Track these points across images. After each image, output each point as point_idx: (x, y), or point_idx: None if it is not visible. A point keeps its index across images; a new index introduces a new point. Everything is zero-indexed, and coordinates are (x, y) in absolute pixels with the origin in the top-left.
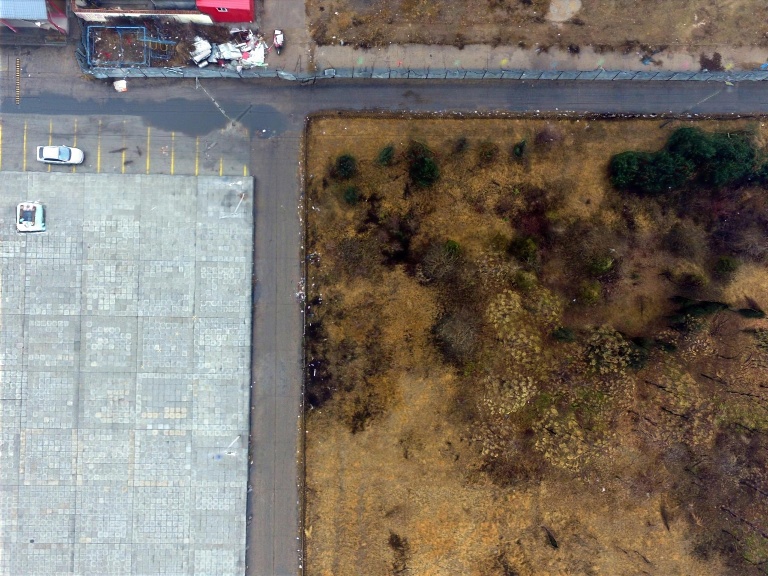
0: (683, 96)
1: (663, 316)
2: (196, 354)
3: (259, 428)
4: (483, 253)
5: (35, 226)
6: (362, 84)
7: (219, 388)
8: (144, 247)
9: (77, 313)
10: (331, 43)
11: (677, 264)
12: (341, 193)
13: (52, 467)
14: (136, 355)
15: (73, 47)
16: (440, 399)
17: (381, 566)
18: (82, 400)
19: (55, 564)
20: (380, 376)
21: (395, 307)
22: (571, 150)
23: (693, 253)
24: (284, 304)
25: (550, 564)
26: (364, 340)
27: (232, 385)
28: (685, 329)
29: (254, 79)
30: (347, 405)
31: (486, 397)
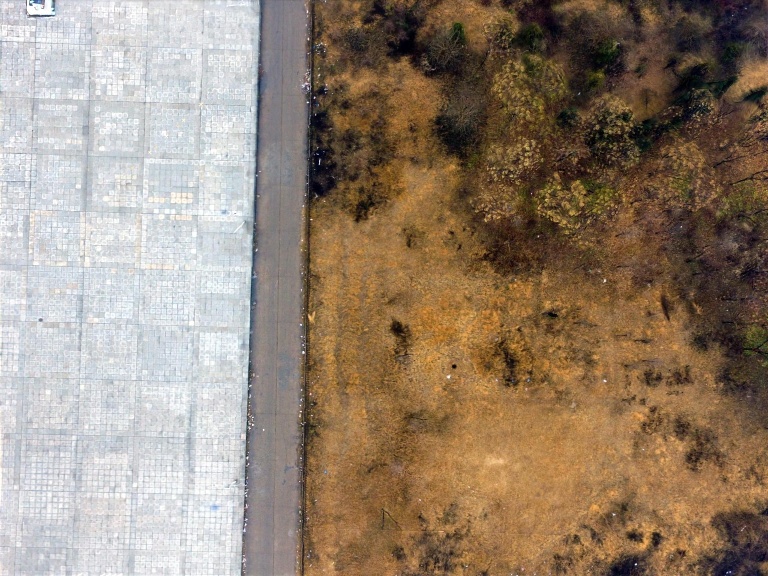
0: None
1: None
2: (202, 141)
3: (264, 217)
4: (489, 15)
5: (45, 9)
6: None
7: (225, 175)
8: (152, 34)
9: (86, 98)
10: None
11: (683, 59)
12: None
13: (60, 248)
14: (143, 140)
15: None
16: (443, 189)
17: (383, 351)
18: (90, 183)
19: (63, 343)
20: (384, 166)
21: (400, 98)
22: None
23: (699, 47)
24: (290, 95)
25: (550, 351)
26: (369, 130)
27: (238, 172)
28: None
29: None
30: (351, 194)
31: (489, 166)
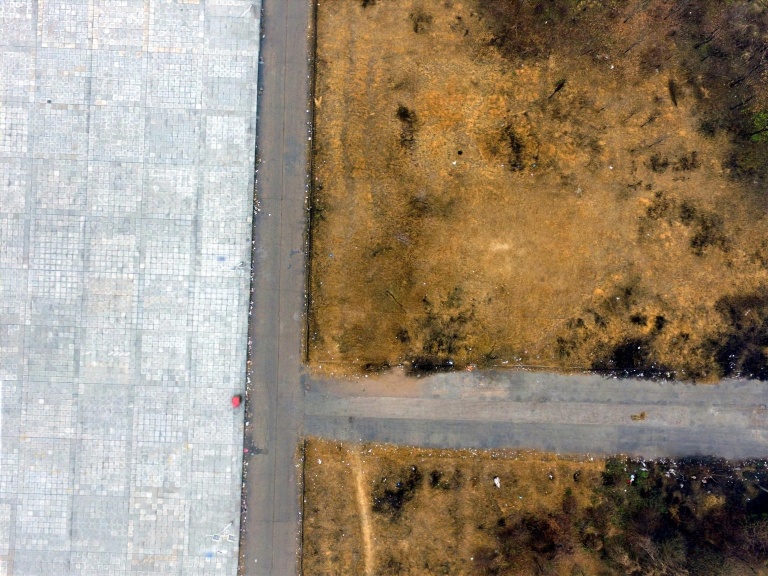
0: None
1: None
2: None
3: (271, 3)
4: None
5: None
6: None
7: None
8: None
9: None
10: None
11: None
12: None
13: (69, 31)
14: None
15: None
16: None
17: (389, 136)
18: None
19: (71, 125)
20: None
21: None
22: None
23: None
24: None
25: (556, 135)
26: None
27: None
28: None
29: None
30: None
31: None
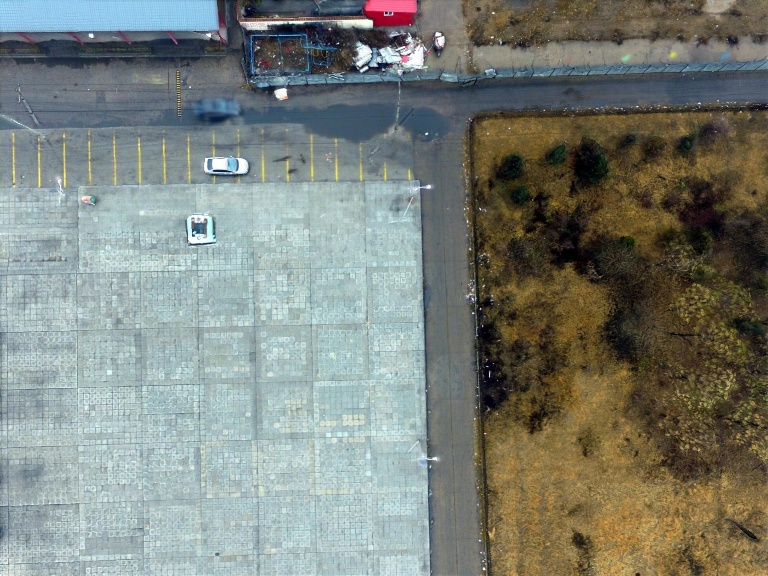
0: None
1: None
2: (371, 360)
3: (436, 432)
4: (678, 248)
5: (207, 238)
6: (523, 83)
7: (396, 393)
8: (315, 255)
9: (251, 324)
10: (490, 43)
11: None
12: (508, 193)
13: (233, 479)
14: (312, 364)
15: (232, 57)
16: (616, 396)
17: (566, 565)
18: (260, 411)
19: None
20: (555, 375)
21: (567, 305)
22: (735, 141)
23: None
24: (455, 307)
25: (735, 556)
26: (537, 339)
27: (409, 390)
28: None
29: (415, 82)
30: (523, 405)
31: (681, 392)
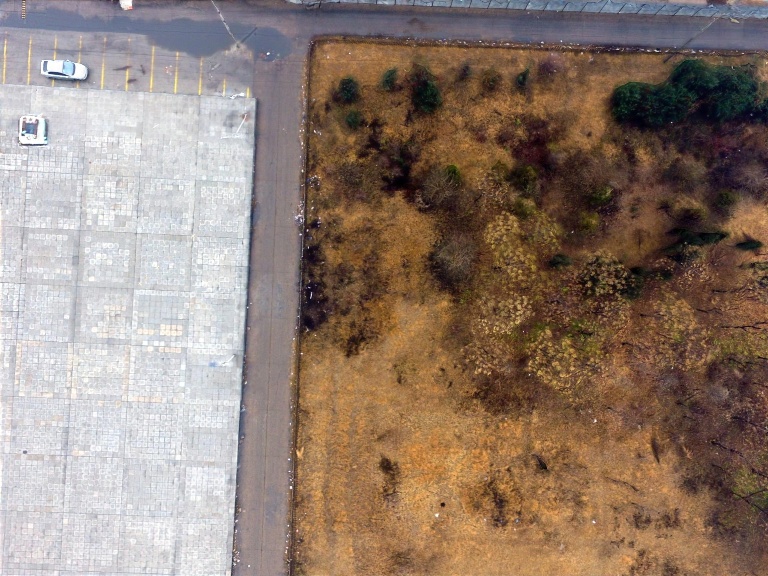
0: (688, 32)
1: (660, 249)
2: (194, 273)
3: (254, 349)
4: (482, 171)
5: (37, 139)
6: (367, 10)
7: (215, 307)
8: (145, 164)
9: (76, 228)
10: None
11: (676, 199)
12: (343, 118)
13: (47, 380)
14: (134, 271)
15: None
16: (435, 326)
17: (371, 489)
18: (79, 314)
19: (47, 476)
20: (376, 301)
21: (393, 233)
22: (574, 82)
23: (693, 188)
24: (283, 227)
25: (539, 492)
26: (361, 265)
27: (228, 305)
28: (682, 258)
29: (260, 1)
30: (342, 329)
31: (481, 317)
